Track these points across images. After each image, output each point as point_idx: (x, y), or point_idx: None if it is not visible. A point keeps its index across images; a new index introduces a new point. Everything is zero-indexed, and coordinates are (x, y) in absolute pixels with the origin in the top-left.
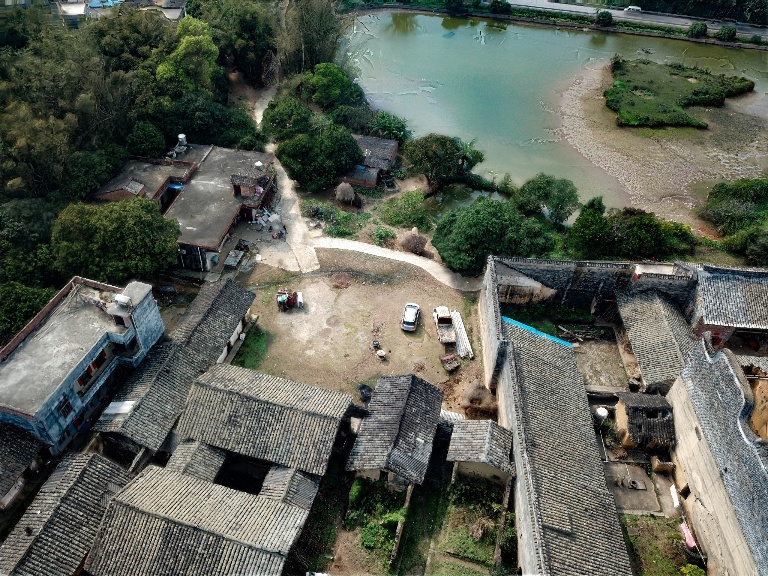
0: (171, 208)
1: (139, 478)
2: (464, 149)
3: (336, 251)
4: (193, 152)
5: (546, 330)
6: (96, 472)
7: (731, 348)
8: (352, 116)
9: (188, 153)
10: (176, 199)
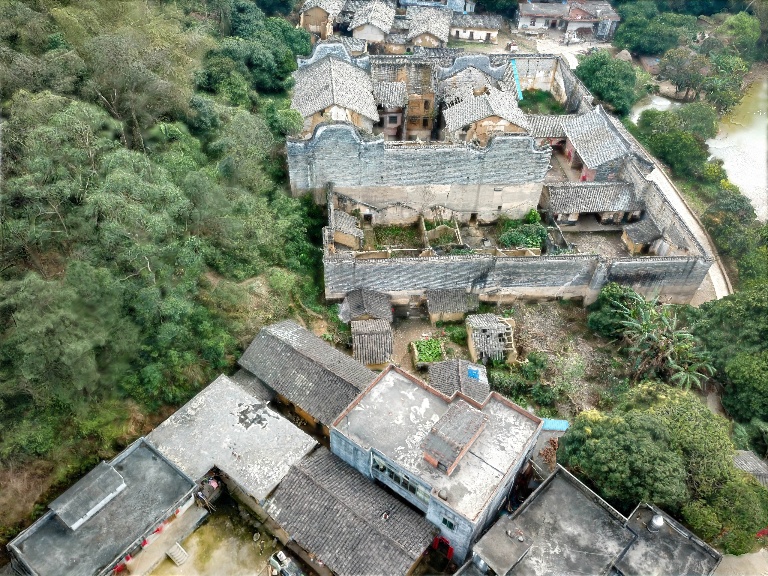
0: (544, 3)
1: (389, 7)
2: (717, 83)
3: (564, 58)
4: (598, 1)
5: (541, 109)
6: (389, 4)
7: (574, 172)
8: (710, 44)
9: (596, 1)
10: (552, 3)
